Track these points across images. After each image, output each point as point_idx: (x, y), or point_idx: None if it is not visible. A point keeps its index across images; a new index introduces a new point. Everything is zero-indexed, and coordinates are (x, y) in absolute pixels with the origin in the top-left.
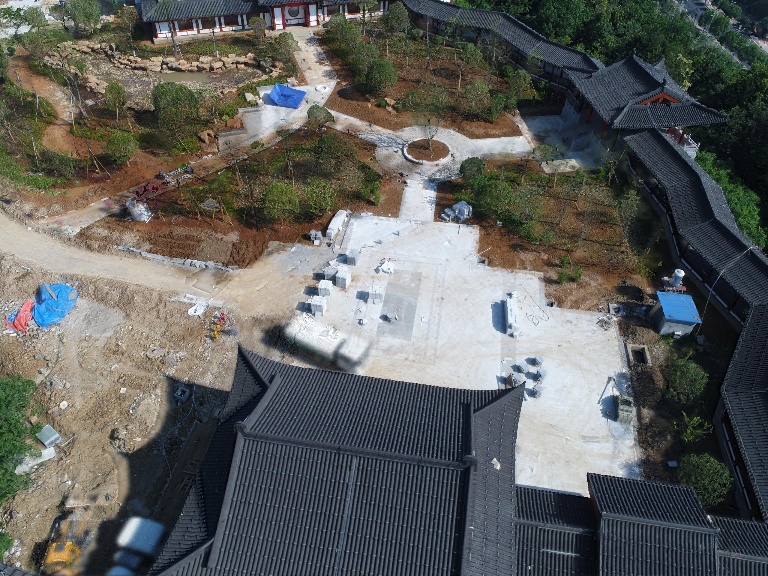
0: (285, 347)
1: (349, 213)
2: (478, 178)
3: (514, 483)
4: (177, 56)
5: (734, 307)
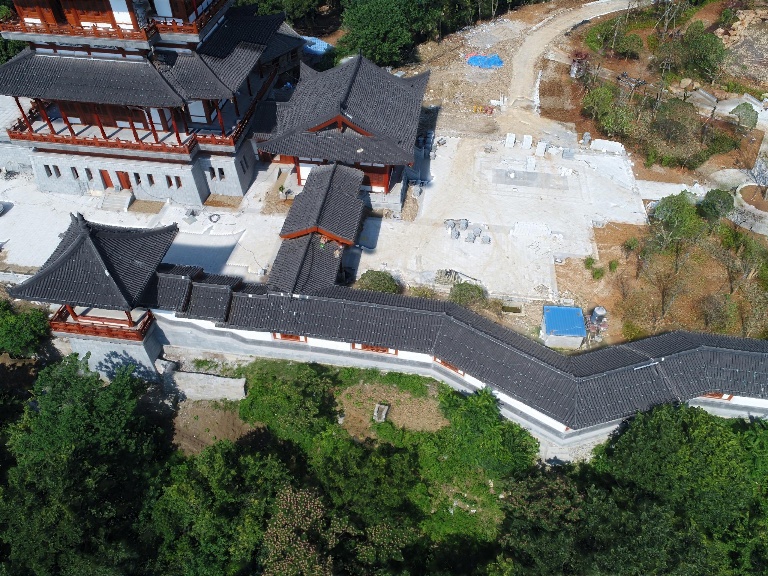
0: (474, 135)
1: (627, 154)
2: (691, 193)
3: (351, 160)
4: None
5: None
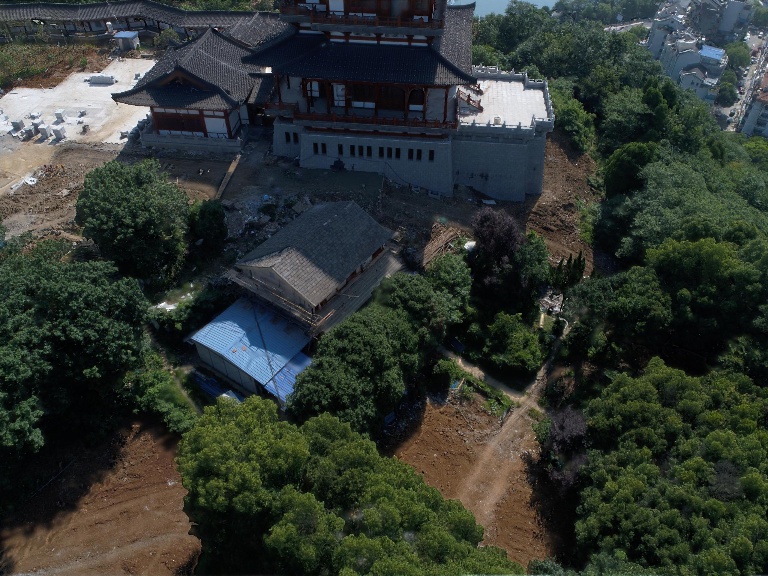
0: None
1: None
2: None
3: None
4: None
5: (130, 29)
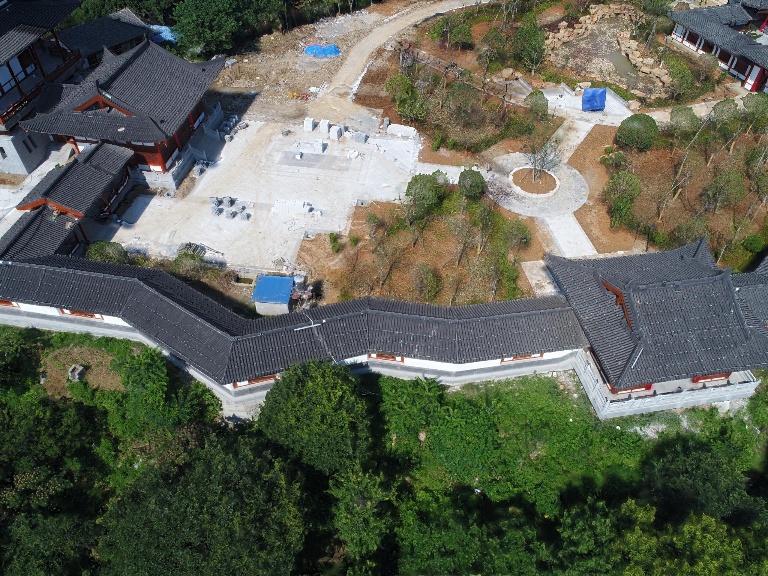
0: (280, 120)
1: (421, 139)
2: (441, 173)
3: (111, 138)
4: (646, 50)
5: None
